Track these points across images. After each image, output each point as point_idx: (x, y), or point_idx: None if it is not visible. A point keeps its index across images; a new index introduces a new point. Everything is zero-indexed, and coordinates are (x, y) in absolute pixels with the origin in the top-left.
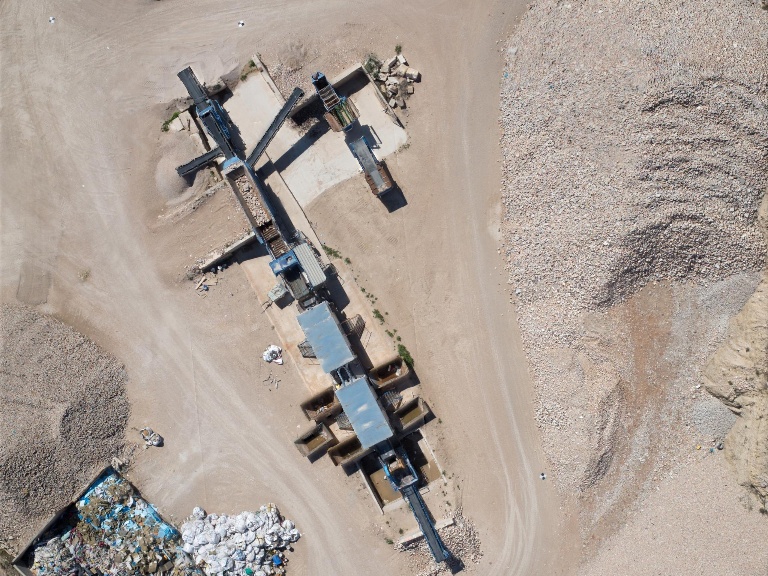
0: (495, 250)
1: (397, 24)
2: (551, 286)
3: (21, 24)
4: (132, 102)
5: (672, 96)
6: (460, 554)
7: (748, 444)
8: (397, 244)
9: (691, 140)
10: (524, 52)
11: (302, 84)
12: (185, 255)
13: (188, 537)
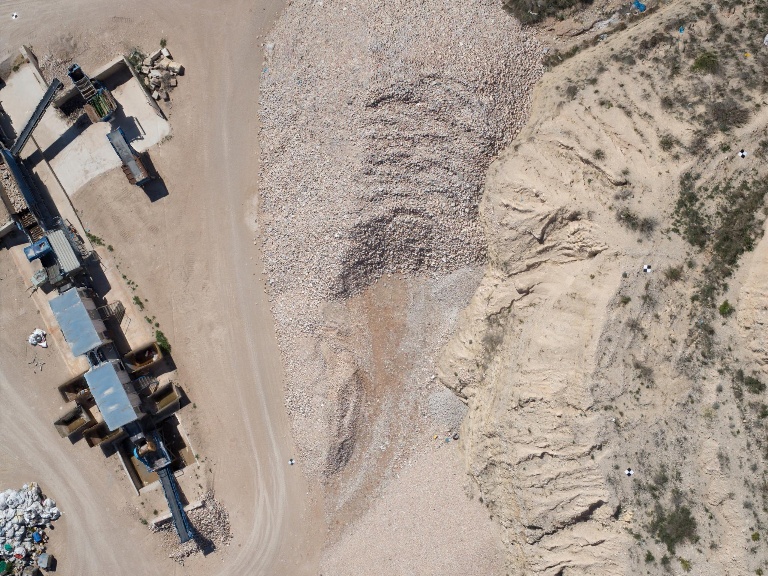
0: (251, 240)
1: (163, 18)
2: (297, 276)
3: None
4: None
5: (392, 92)
6: (211, 536)
7: (470, 434)
8: (158, 233)
9: (411, 136)
10: (280, 47)
11: None
12: None
13: None
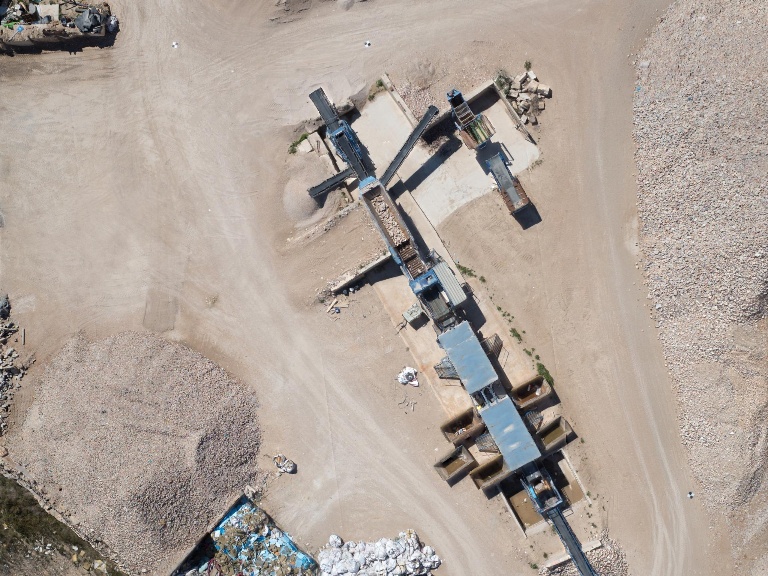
0: (633, 265)
1: (526, 40)
2: (695, 300)
3: (144, 50)
4: (258, 125)
5: None
6: None
7: None
8: (532, 261)
9: None
10: (658, 65)
11: (431, 103)
12: (316, 277)
13: (326, 566)
